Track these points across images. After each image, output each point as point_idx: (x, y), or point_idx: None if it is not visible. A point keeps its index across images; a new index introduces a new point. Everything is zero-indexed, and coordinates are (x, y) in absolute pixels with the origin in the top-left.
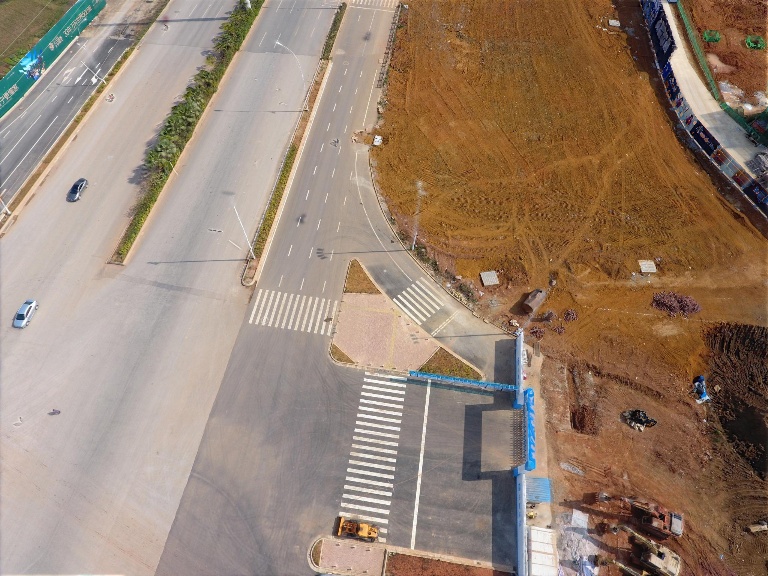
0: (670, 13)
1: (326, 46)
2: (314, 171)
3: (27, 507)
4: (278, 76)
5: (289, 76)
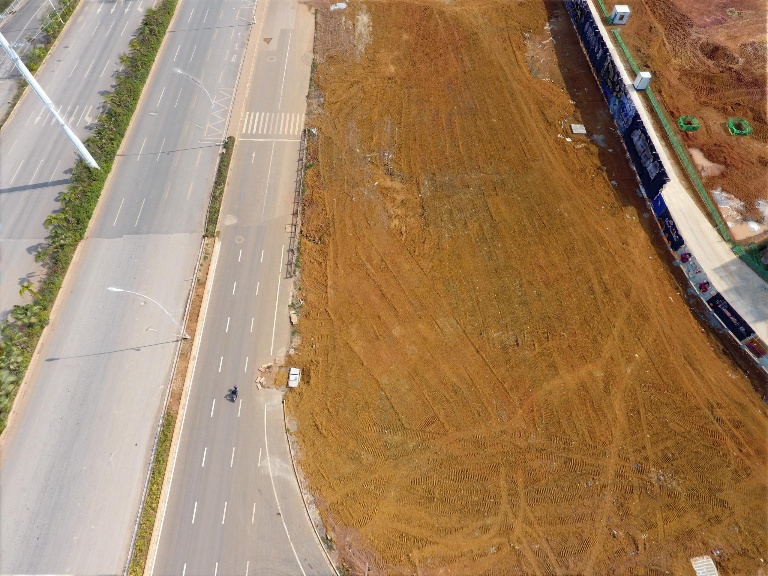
0: (641, 107)
1: (210, 213)
2: (203, 459)
3: None
4: (142, 278)
5: (159, 275)
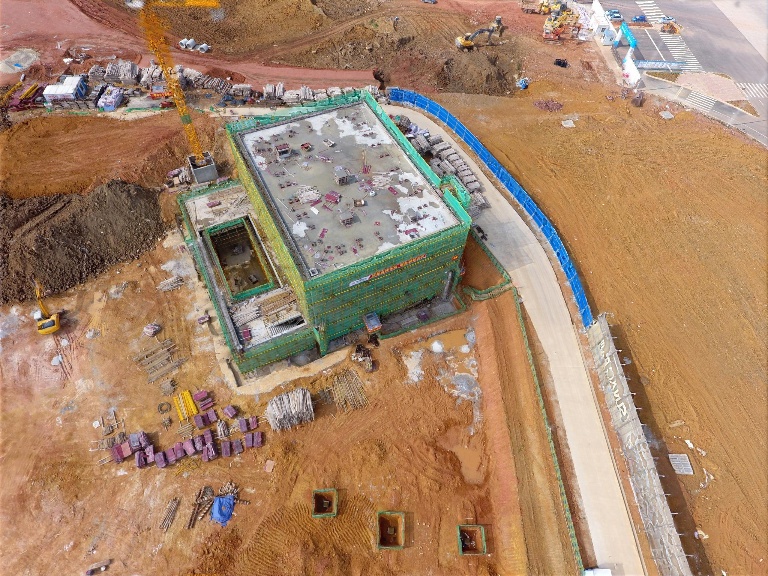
0: (591, 516)
1: None
2: None
3: None
4: None
5: None
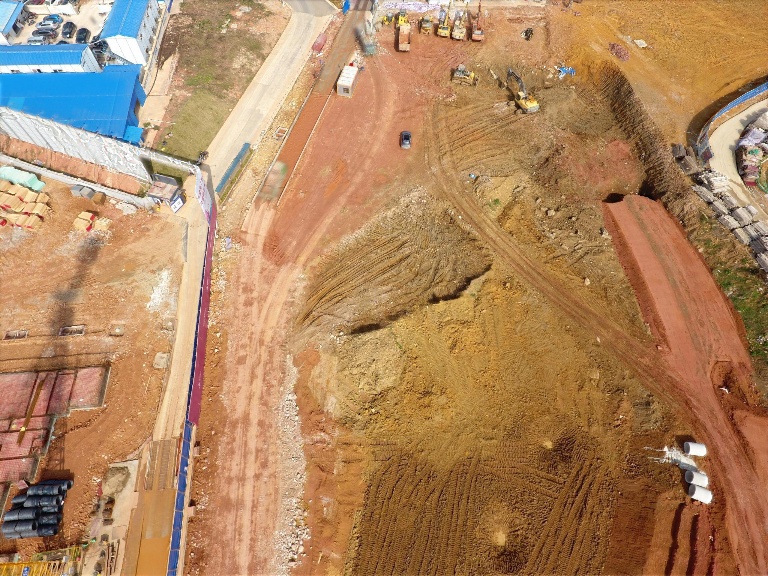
0: None
1: None
2: None
3: None
4: None
5: None
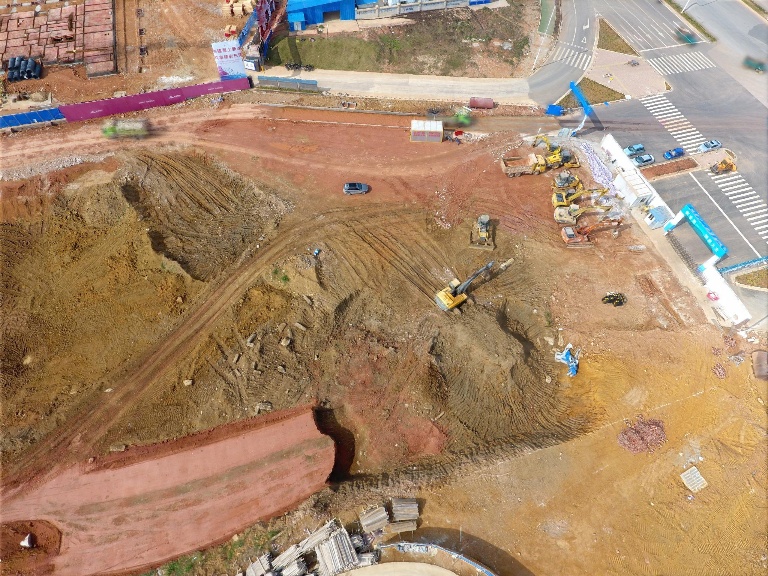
0: None
1: None
2: None
3: None
4: None
5: None
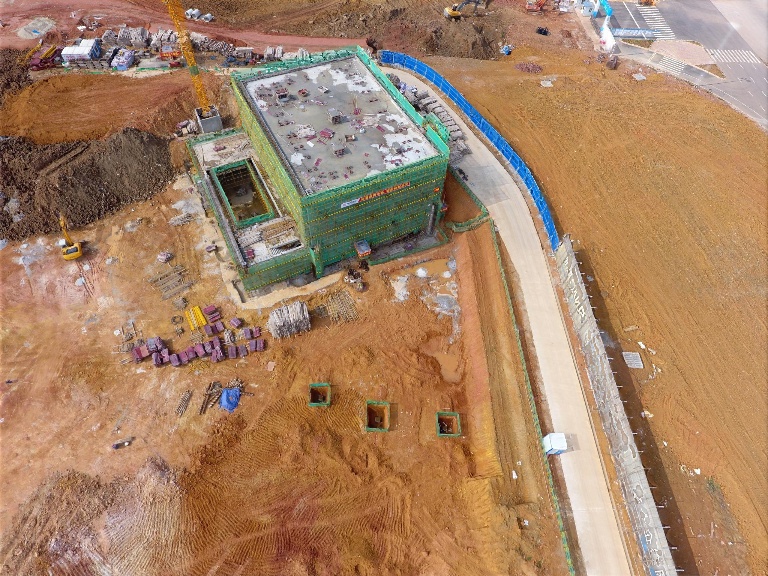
0: (552, 398)
1: None
2: None
3: (767, 4)
4: None
5: None
